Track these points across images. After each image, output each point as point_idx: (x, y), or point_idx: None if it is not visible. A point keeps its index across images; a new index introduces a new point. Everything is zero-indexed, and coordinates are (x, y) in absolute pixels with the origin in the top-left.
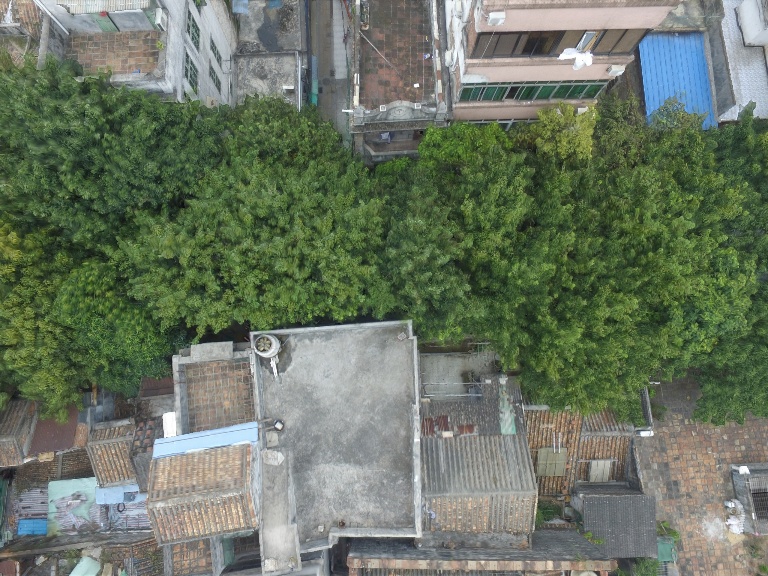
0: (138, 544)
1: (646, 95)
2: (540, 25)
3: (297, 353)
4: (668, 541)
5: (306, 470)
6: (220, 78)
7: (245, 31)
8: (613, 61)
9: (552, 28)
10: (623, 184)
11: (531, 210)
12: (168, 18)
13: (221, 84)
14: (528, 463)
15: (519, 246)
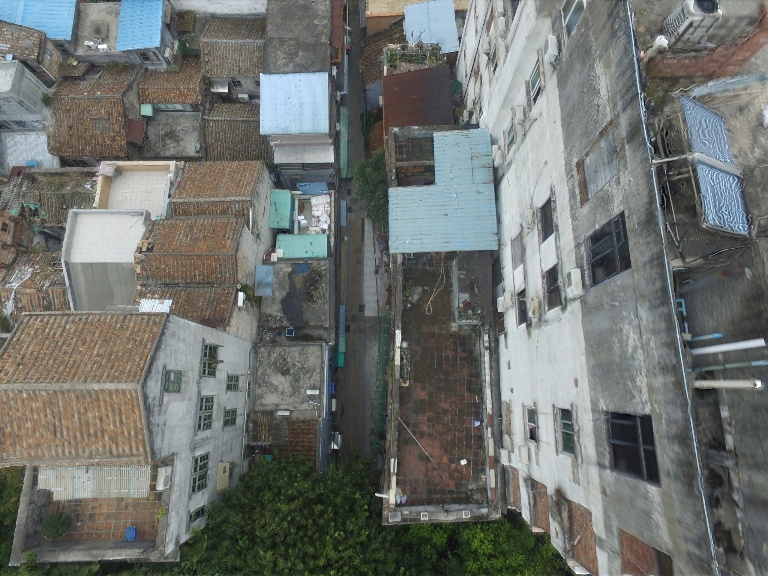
0: None
1: None
2: None
3: None
4: None
5: None
6: (236, 404)
7: (268, 301)
8: None
9: None
10: None
11: None
12: (173, 464)
13: (237, 409)
14: None
15: None
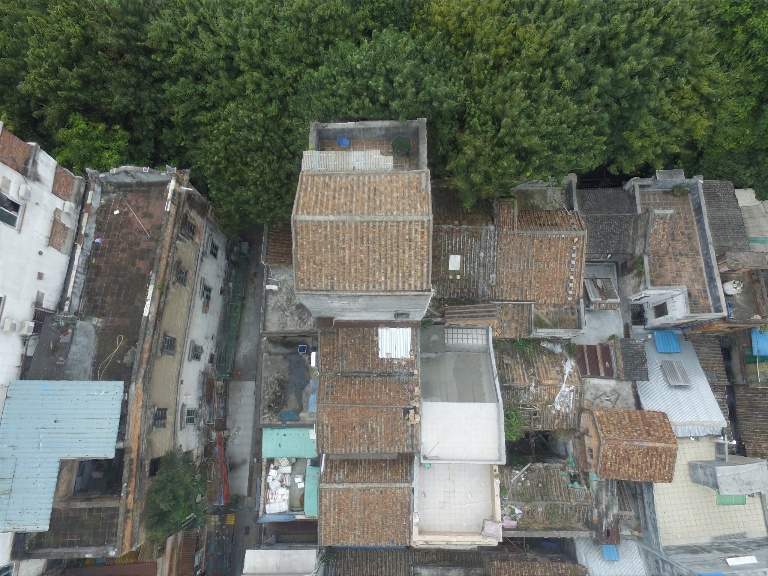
0: None
1: None
2: None
3: None
4: None
5: None
6: None
7: None
8: None
9: None
10: None
11: None
12: None
13: None
14: None
15: None
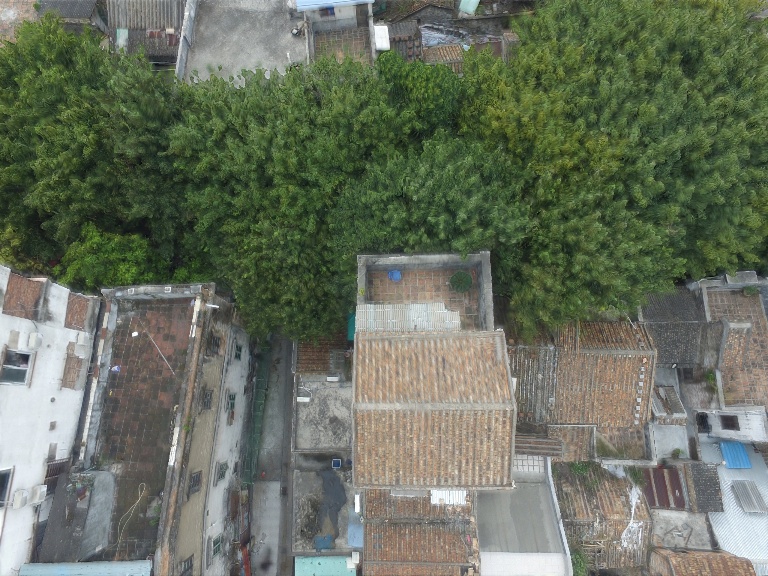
0: (425, 6)
1: None
2: None
3: None
4: (42, 0)
5: (278, 8)
6: None
7: None
8: None
9: None
10: None
11: None
12: None
13: None
14: (110, 5)
15: None
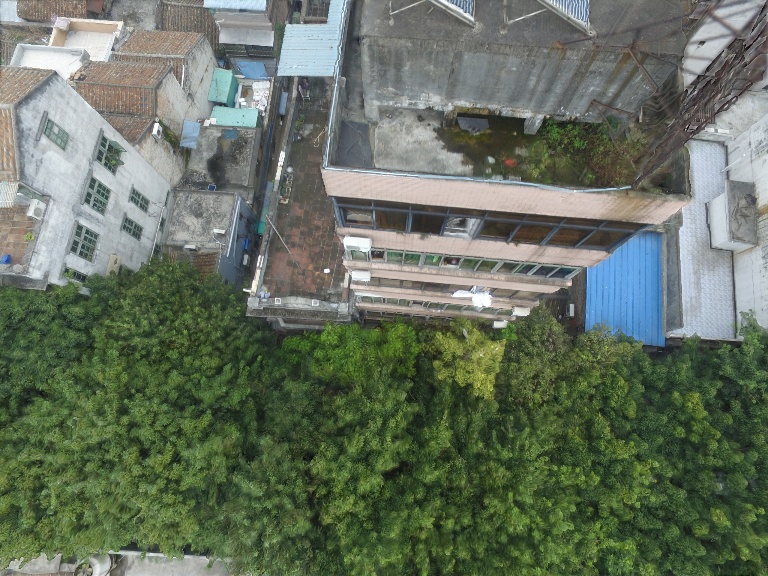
0: None
1: (588, 296)
2: (418, 278)
3: (132, 572)
4: None
5: None
6: (143, 223)
7: (195, 160)
8: (516, 303)
9: (433, 281)
10: (504, 454)
11: (407, 454)
12: (48, 204)
13: (143, 229)
14: None
15: (381, 502)
